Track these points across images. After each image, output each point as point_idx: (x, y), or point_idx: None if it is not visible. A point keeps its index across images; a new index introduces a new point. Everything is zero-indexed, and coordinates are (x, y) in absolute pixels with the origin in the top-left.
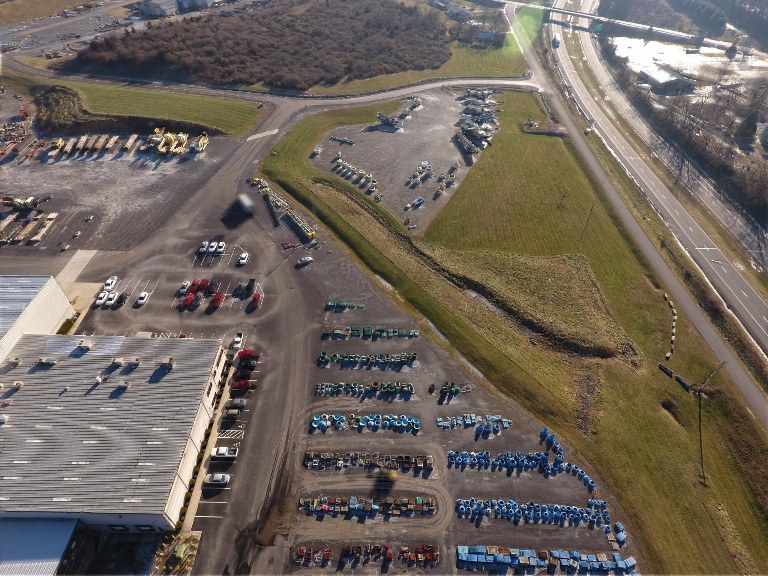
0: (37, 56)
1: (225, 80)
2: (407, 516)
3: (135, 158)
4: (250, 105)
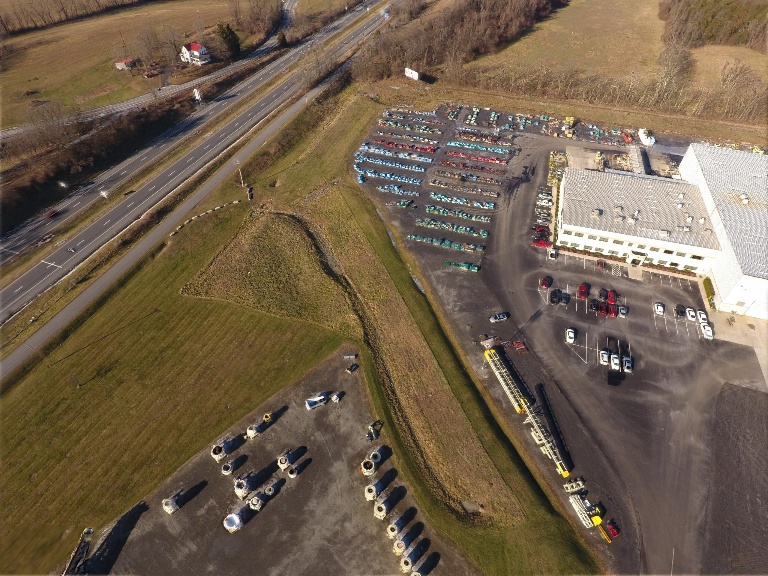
0: None
1: None
2: None
3: None
4: None
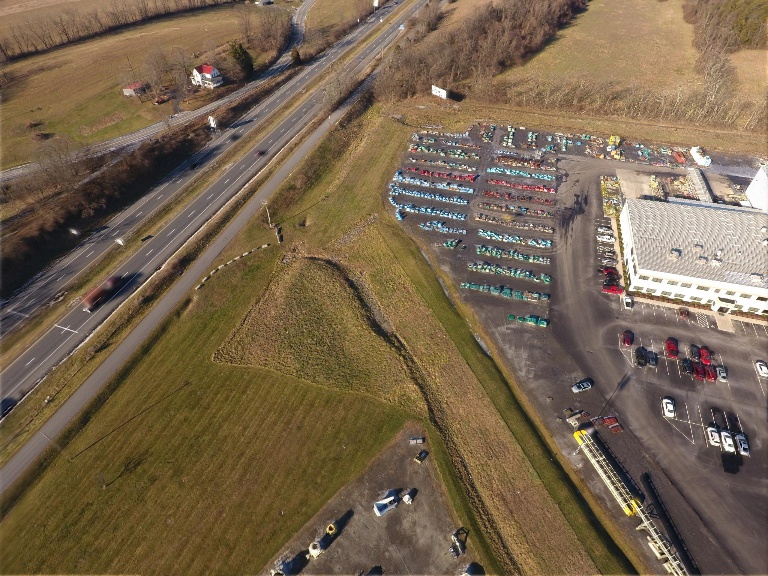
0: None
1: None
2: (495, 204)
3: None
4: None
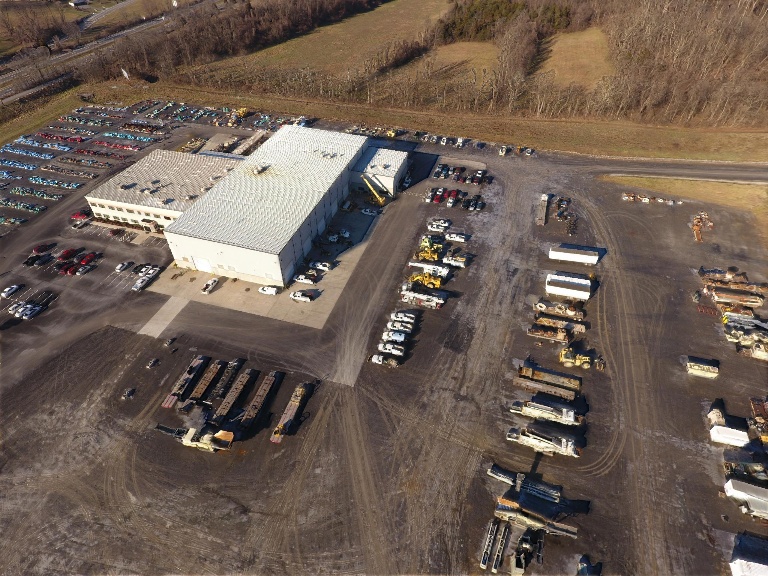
0: None
1: None
2: None
3: None
4: None
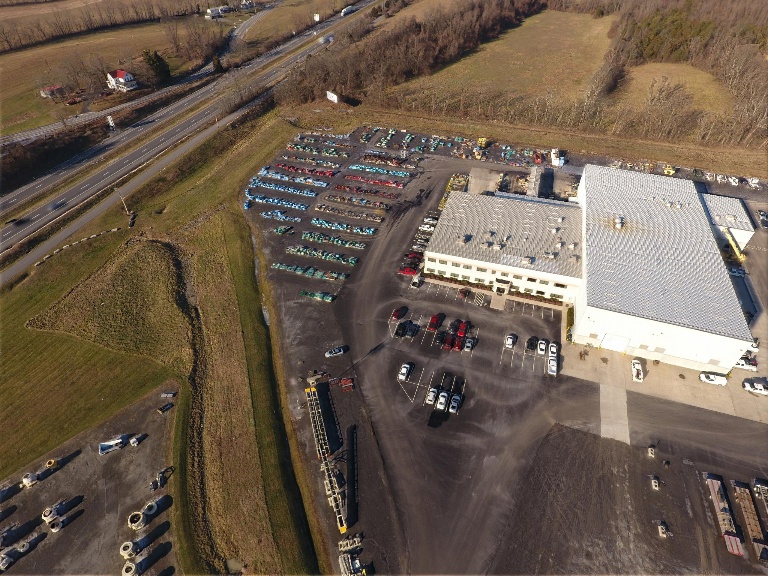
0: None
1: None
2: None
3: None
4: None
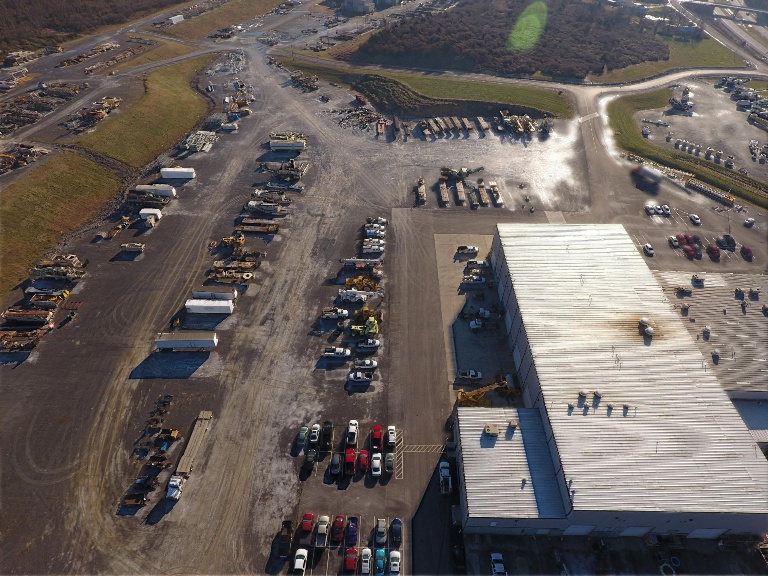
0: (303, 49)
1: (510, 69)
2: None
3: (499, 137)
4: (550, 92)
